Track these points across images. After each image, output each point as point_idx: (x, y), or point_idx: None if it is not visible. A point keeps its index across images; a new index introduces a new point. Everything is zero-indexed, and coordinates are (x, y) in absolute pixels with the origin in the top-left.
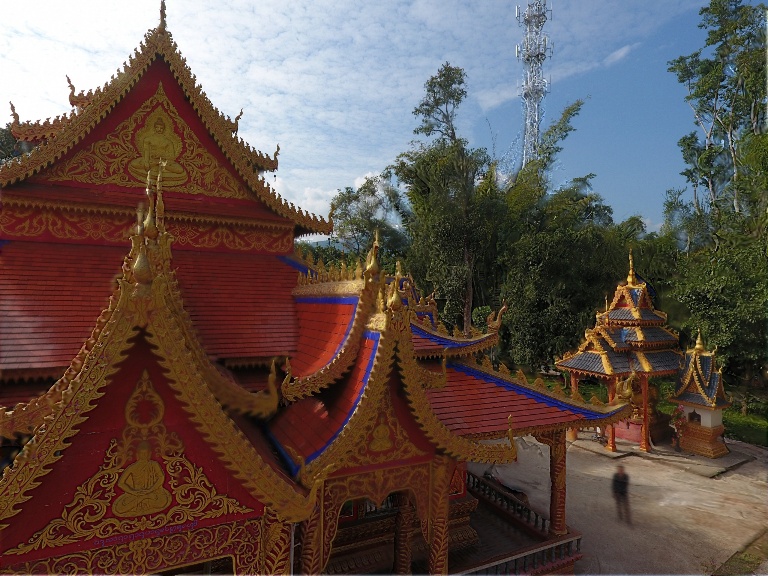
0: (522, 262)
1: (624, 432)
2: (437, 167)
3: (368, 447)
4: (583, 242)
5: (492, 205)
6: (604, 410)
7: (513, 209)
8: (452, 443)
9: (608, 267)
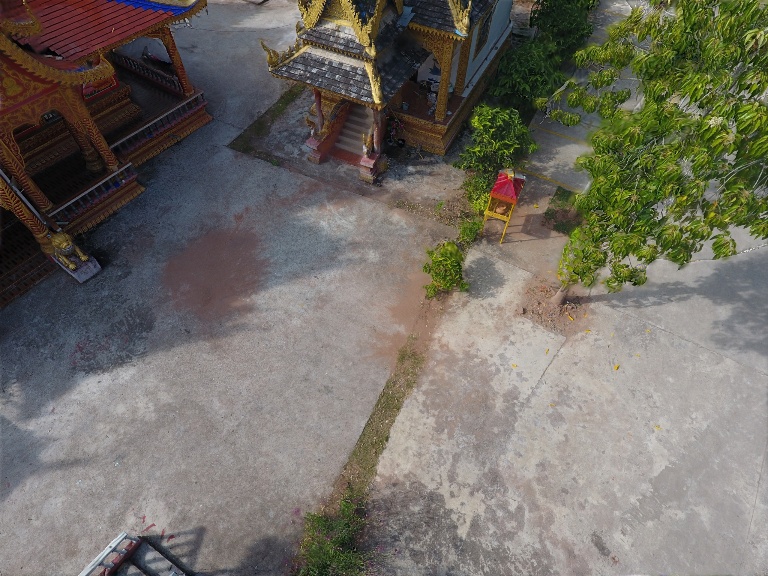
0: None
1: None
2: None
3: (5, 95)
4: None
5: None
6: (187, 4)
7: None
8: (63, 77)
9: None
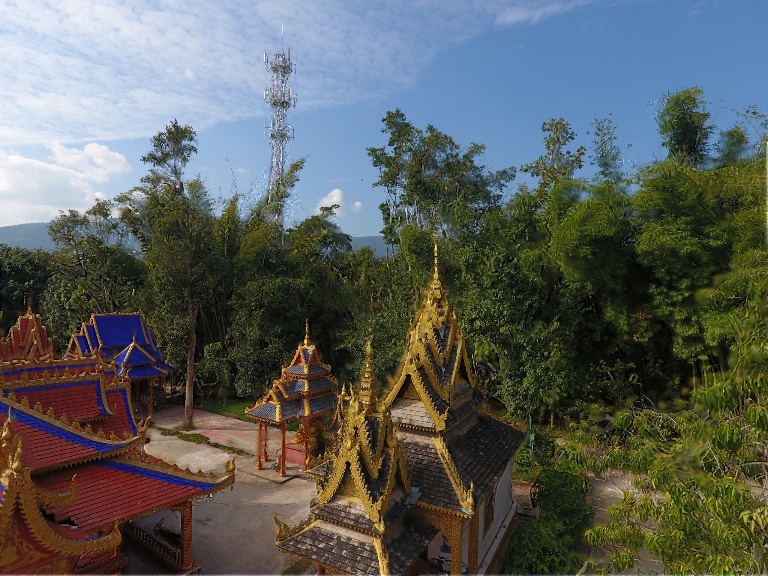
0: (247, 306)
1: (297, 458)
2: (161, 223)
3: None
4: (297, 291)
5: (214, 262)
6: (216, 481)
7: (248, 251)
8: (67, 546)
9: (330, 301)
